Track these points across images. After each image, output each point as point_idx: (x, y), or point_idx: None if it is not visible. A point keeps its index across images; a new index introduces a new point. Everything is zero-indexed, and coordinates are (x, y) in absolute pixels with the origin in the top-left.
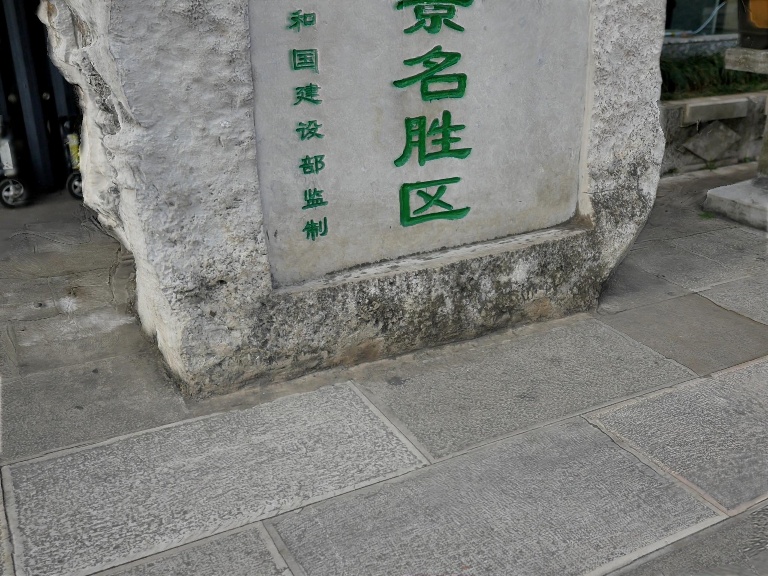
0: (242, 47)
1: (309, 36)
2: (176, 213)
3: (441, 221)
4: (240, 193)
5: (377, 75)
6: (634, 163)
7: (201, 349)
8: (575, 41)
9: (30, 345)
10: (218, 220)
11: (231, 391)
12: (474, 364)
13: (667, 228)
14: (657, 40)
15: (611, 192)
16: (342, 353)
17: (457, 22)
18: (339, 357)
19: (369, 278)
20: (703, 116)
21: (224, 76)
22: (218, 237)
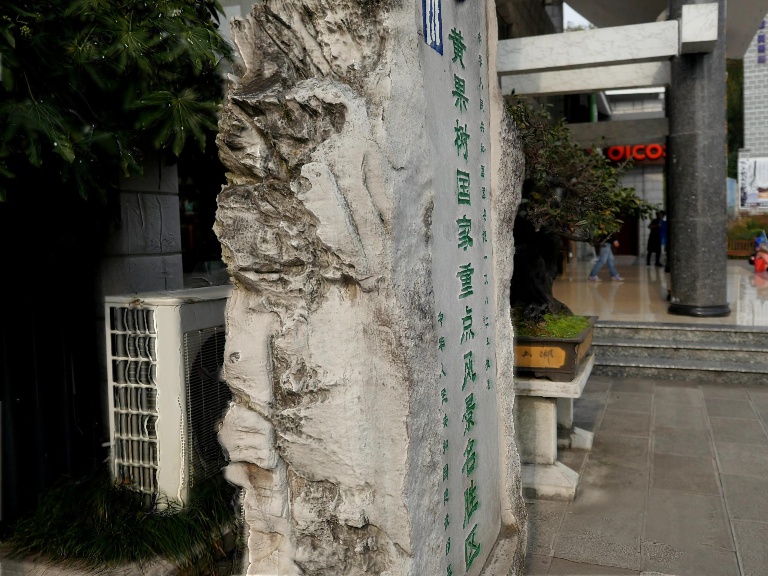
0: (440, 477)
1: None
2: None
3: None
4: None
5: None
6: (515, 480)
7: None
8: (494, 413)
9: None
10: None
11: None
12: None
13: None
14: None
15: (514, 504)
16: None
17: None
18: None
19: None
20: None
21: (434, 501)
22: None
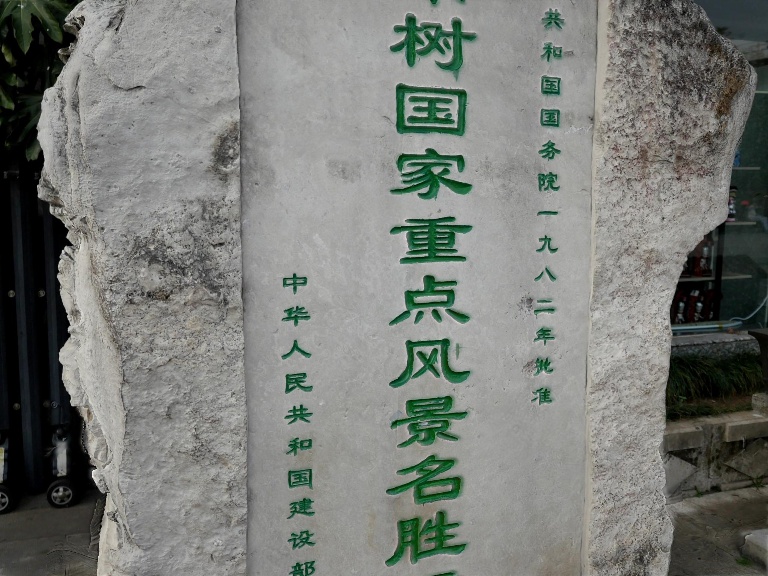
0: (239, 477)
1: (305, 459)
2: None
3: None
4: None
5: (370, 486)
6: (640, 551)
7: None
8: (572, 440)
9: None
10: None
11: None
12: None
13: None
14: (658, 435)
15: None
16: None
17: (450, 434)
18: None
19: None
20: (748, 436)
21: (221, 501)
22: None
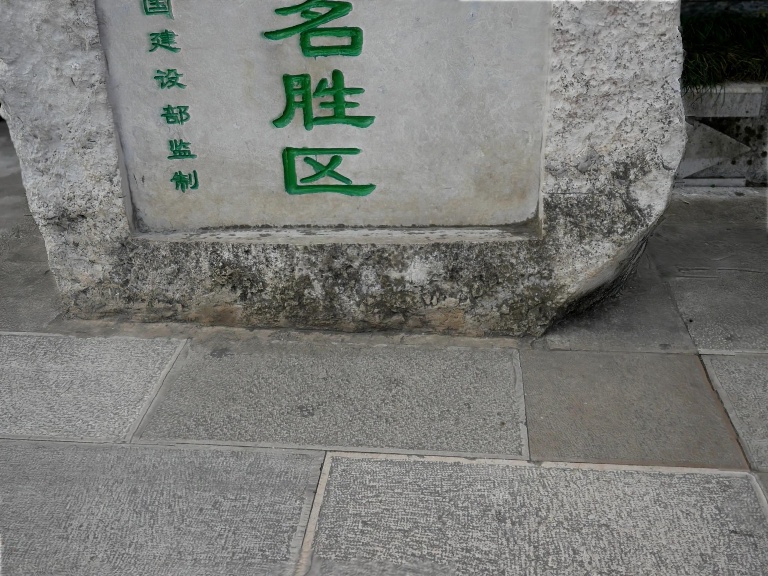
0: None
1: None
2: (40, 146)
3: (337, 195)
4: (92, 135)
5: (243, 24)
6: (627, 162)
7: (66, 274)
8: None
9: (41, 238)
10: (77, 158)
11: (91, 318)
12: (311, 359)
13: None
14: None
15: (582, 196)
16: (197, 310)
17: None
18: (194, 313)
19: (224, 241)
20: None
21: (69, 19)
22: (79, 174)
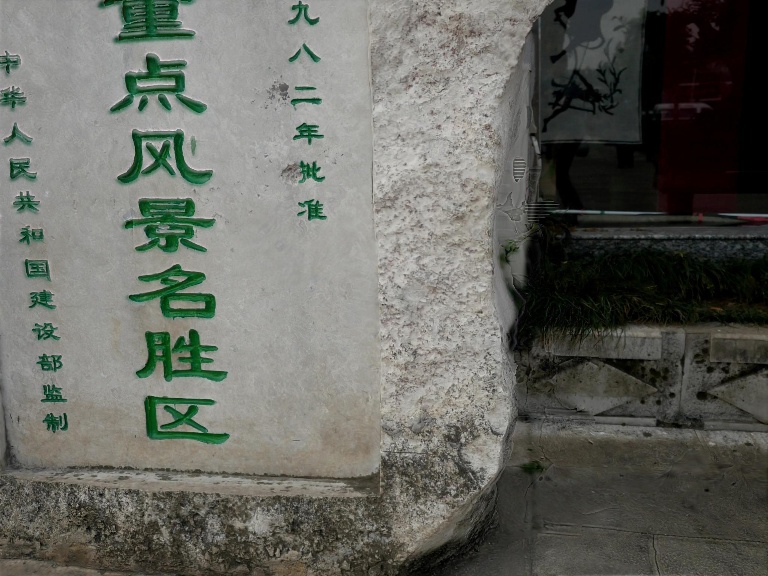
0: None
1: (39, 248)
2: None
3: (194, 442)
4: None
5: (111, 288)
6: (457, 426)
7: None
8: (359, 270)
9: None
10: None
11: None
12: None
13: (690, 515)
14: (483, 277)
15: (418, 456)
16: (54, 549)
17: (197, 242)
18: (51, 552)
19: (81, 483)
20: None
21: None
22: None
